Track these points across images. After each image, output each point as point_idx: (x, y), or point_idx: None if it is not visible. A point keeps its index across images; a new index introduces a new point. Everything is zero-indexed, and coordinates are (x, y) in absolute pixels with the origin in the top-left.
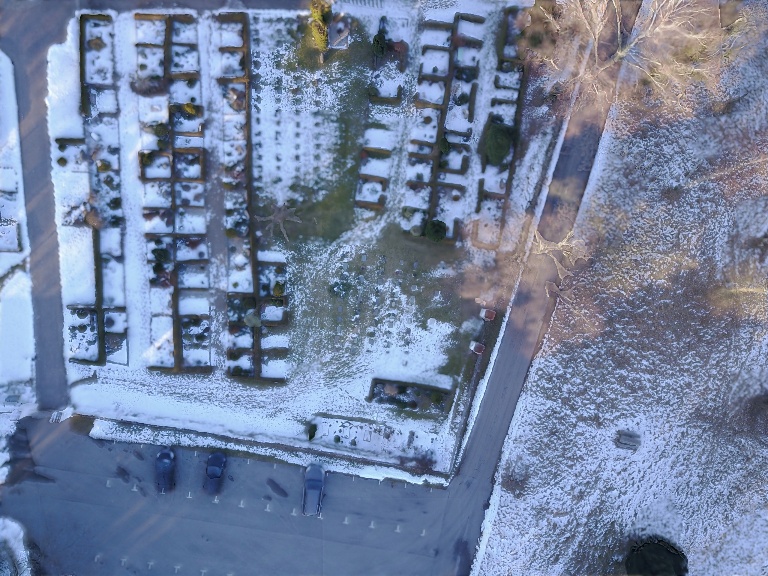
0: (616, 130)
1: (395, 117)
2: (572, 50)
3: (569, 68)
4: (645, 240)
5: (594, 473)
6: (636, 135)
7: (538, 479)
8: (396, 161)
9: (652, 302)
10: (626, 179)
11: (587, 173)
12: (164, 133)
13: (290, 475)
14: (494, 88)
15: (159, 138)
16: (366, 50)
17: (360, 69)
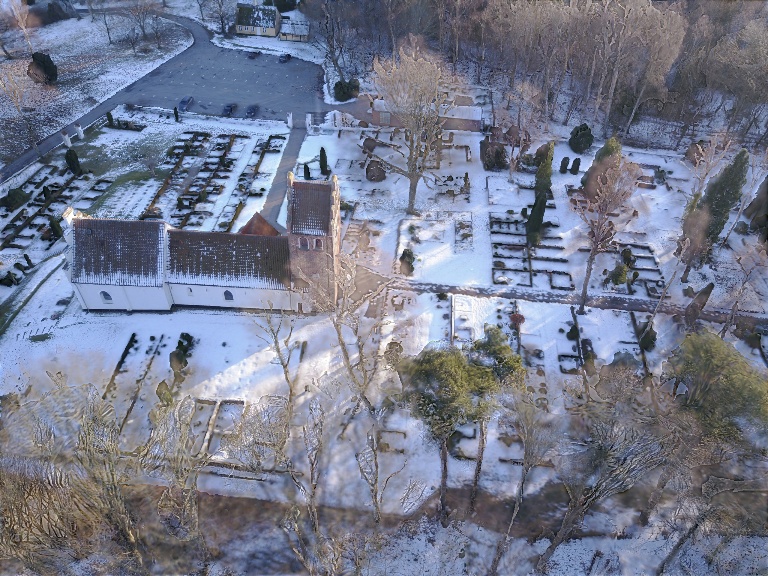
0: None
1: None
2: None
3: None
4: None
5: None
6: None
7: None
8: (80, 197)
9: None
10: None
11: None
12: None
13: (195, 110)
14: (1, 222)
15: None
16: None
17: None
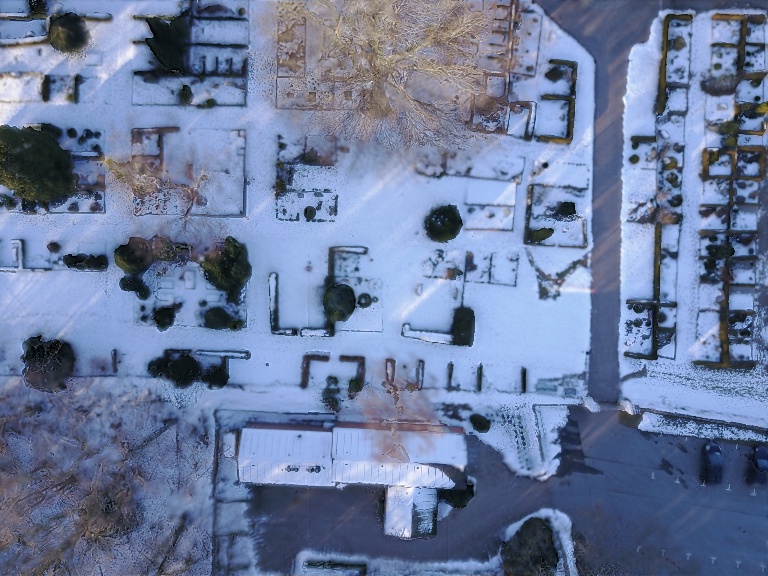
0: None
1: None
2: None
3: None
4: None
5: None
6: None
7: None
8: None
9: None
10: None
11: None
12: None
13: None
14: None
15: (722, 136)
16: None
17: None
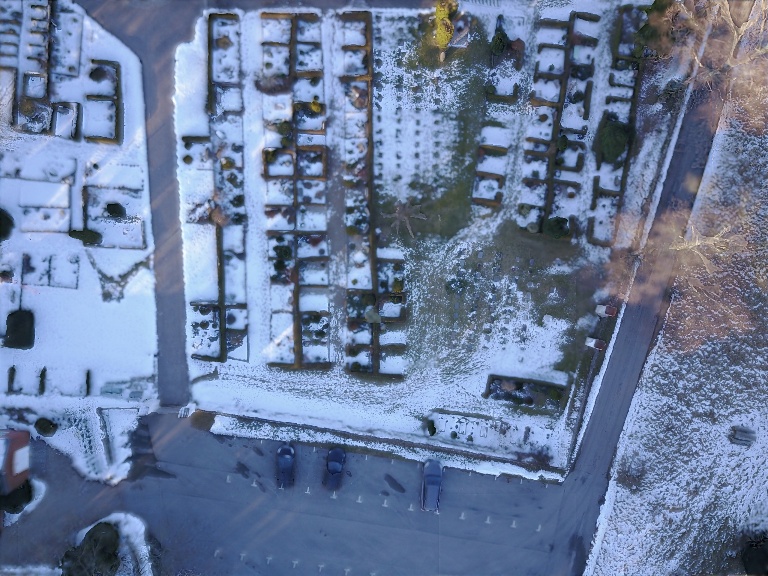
0: (730, 127)
1: (511, 115)
2: (687, 48)
3: (684, 66)
4: (760, 237)
5: (709, 469)
6: (751, 132)
7: (654, 475)
8: (512, 159)
9: (767, 298)
10: (741, 176)
11: (701, 170)
12: (288, 131)
13: (407, 471)
14: (608, 86)
15: (282, 136)
16: (484, 48)
17: (478, 67)
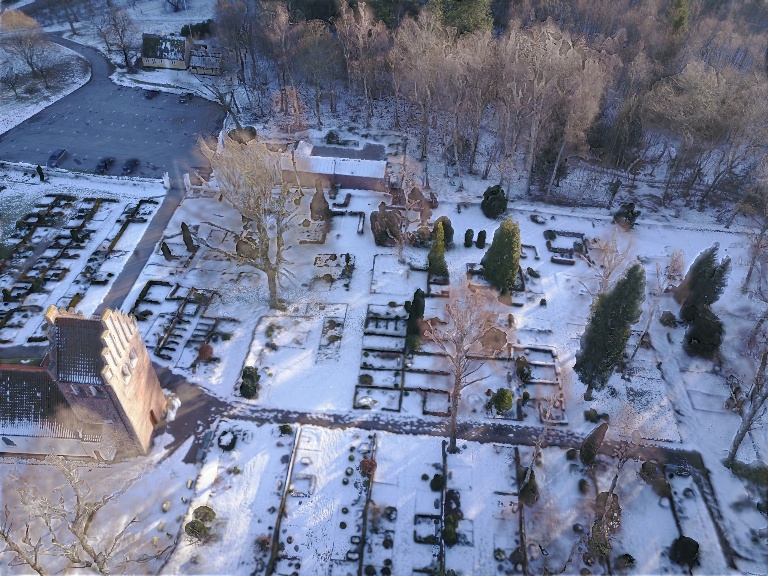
0: None
1: None
2: None
3: None
4: None
5: None
6: None
7: None
8: None
9: None
10: None
11: None
12: None
13: (67, 166)
14: None
15: None
16: None
17: None
